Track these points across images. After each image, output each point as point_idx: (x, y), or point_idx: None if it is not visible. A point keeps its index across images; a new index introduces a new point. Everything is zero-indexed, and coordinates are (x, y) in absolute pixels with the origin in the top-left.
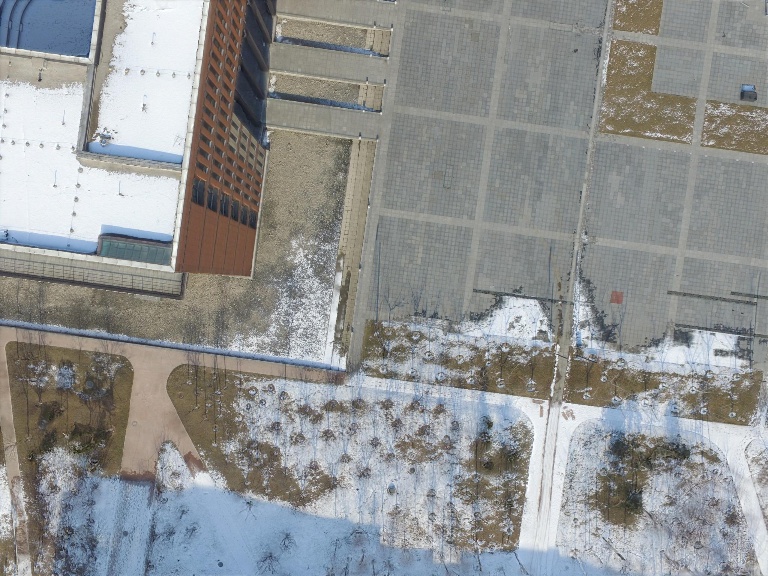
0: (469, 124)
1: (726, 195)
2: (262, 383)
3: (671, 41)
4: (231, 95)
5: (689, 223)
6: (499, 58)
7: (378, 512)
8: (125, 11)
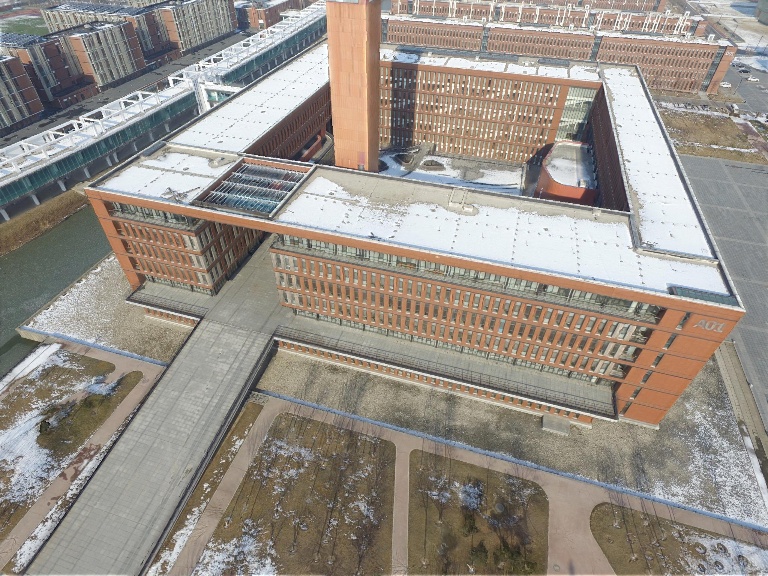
0: None
1: None
2: (708, 540)
3: None
4: None
5: None
6: None
7: None
8: (640, 202)
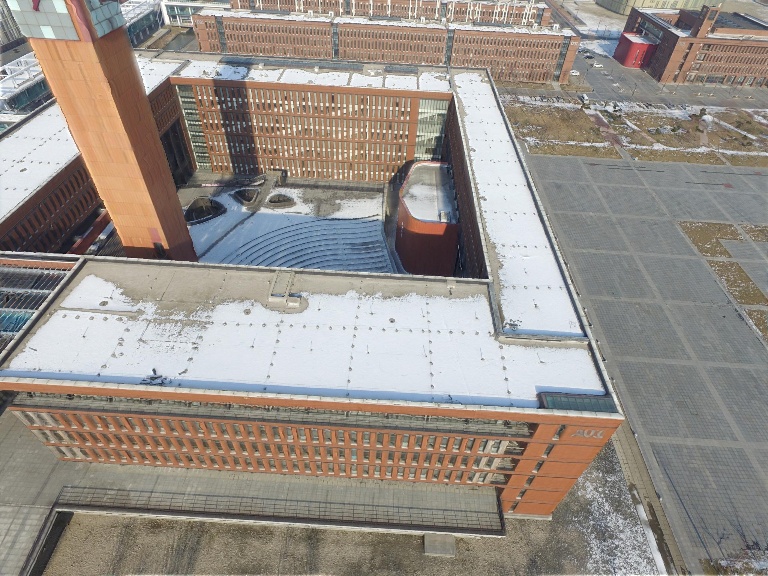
0: (680, 365)
1: None
2: None
3: None
4: None
5: None
6: (673, 323)
7: None
8: (500, 259)
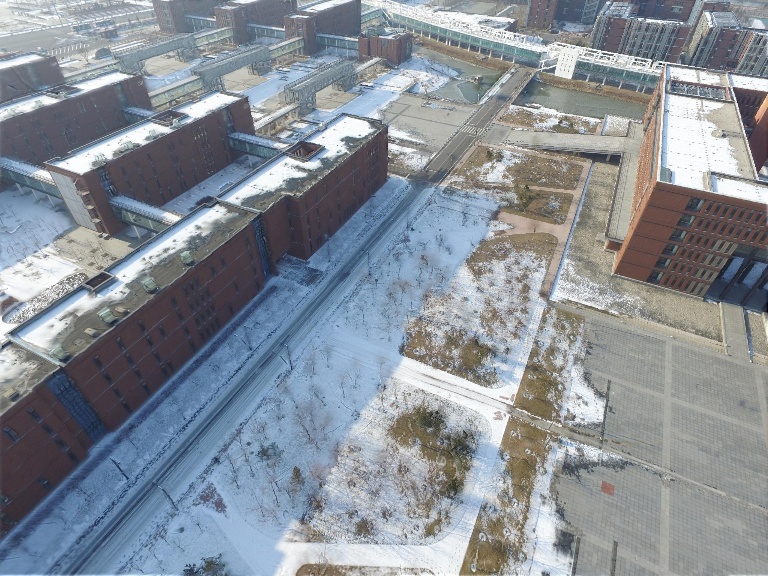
0: (760, 416)
1: None
2: (544, 264)
3: None
4: (750, 242)
5: None
6: None
7: (453, 290)
8: None
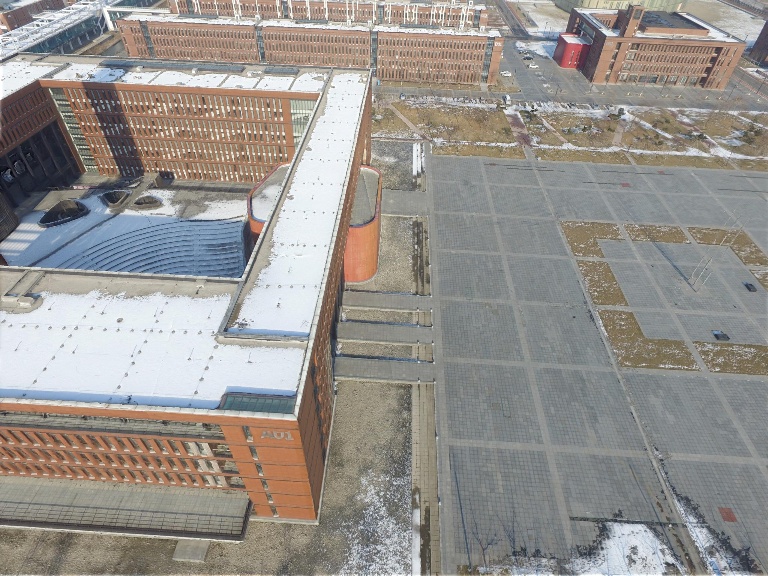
0: (510, 367)
1: (761, 408)
2: None
3: (640, 309)
4: None
5: (746, 433)
6: (518, 324)
7: None
8: (271, 258)
